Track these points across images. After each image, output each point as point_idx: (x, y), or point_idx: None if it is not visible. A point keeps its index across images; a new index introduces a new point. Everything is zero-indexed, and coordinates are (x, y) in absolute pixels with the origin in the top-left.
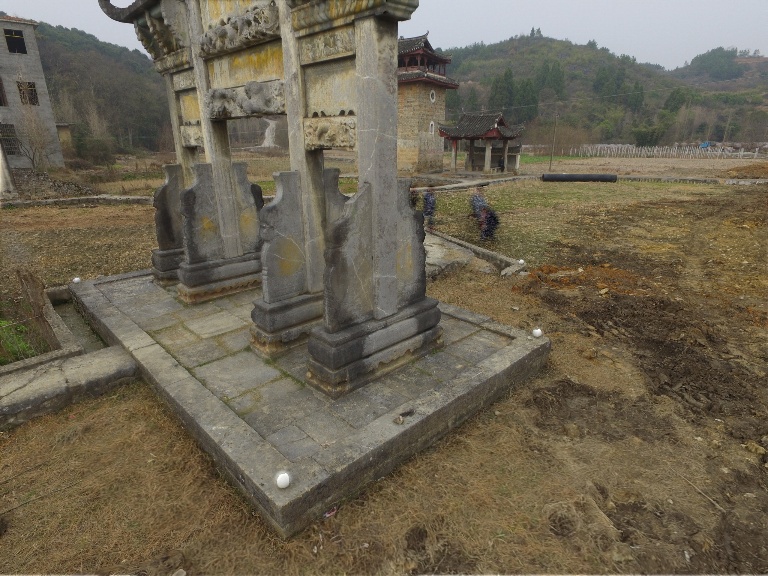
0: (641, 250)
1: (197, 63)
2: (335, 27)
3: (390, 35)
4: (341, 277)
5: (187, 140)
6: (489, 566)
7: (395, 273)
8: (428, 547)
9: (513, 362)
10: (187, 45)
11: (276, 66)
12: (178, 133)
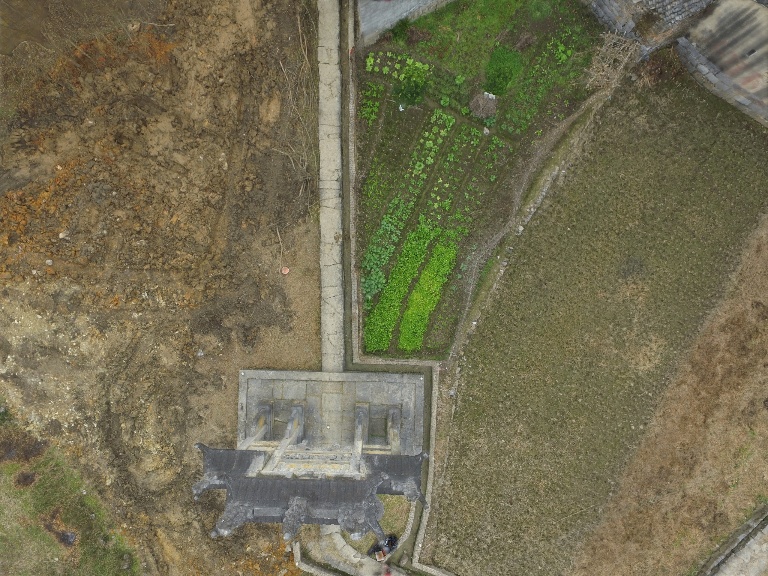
0: None
1: (355, 456)
2: None
3: None
4: None
5: None
6: (213, 391)
7: None
8: (224, 387)
9: None
10: None
11: None
12: None
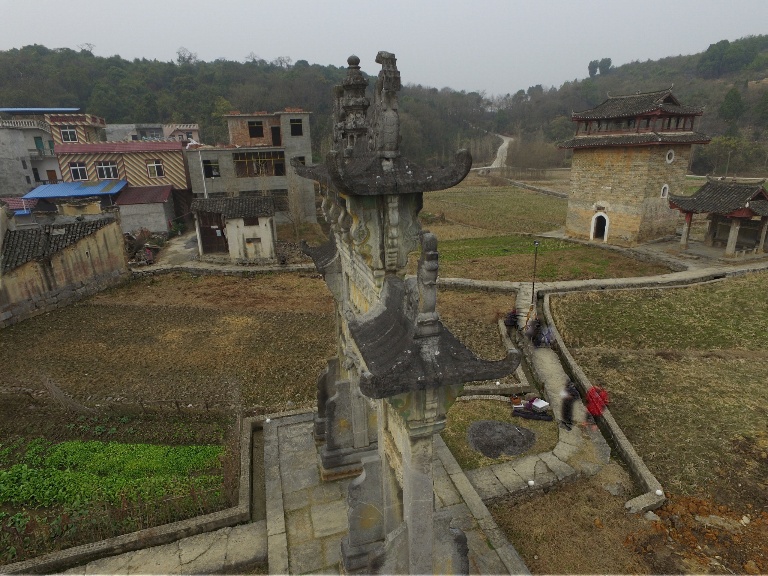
0: None
1: None
2: None
3: (424, 439)
4: None
5: (342, 348)
6: None
7: None
8: None
9: None
10: (341, 300)
11: None
12: (338, 338)
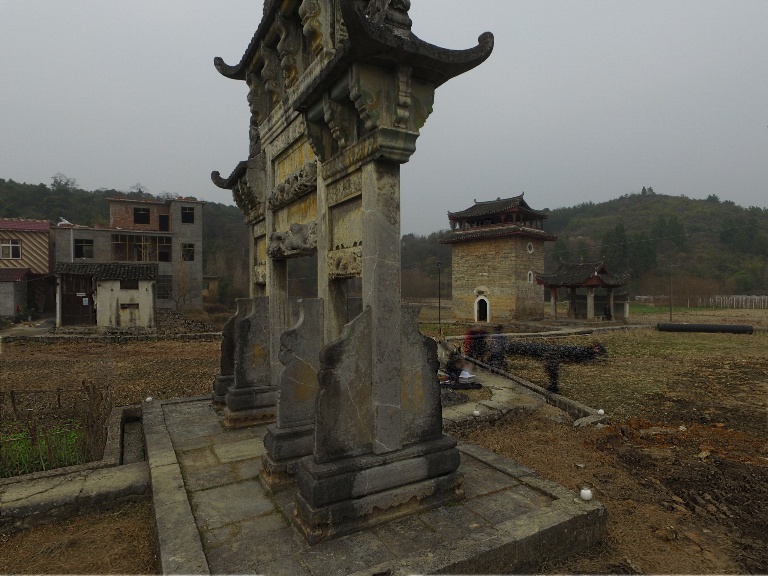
0: None
1: (268, 214)
2: (349, 173)
3: (391, 175)
4: (333, 401)
5: (257, 277)
6: None
7: (398, 403)
8: None
9: (543, 528)
10: (263, 201)
11: (315, 210)
12: (252, 272)
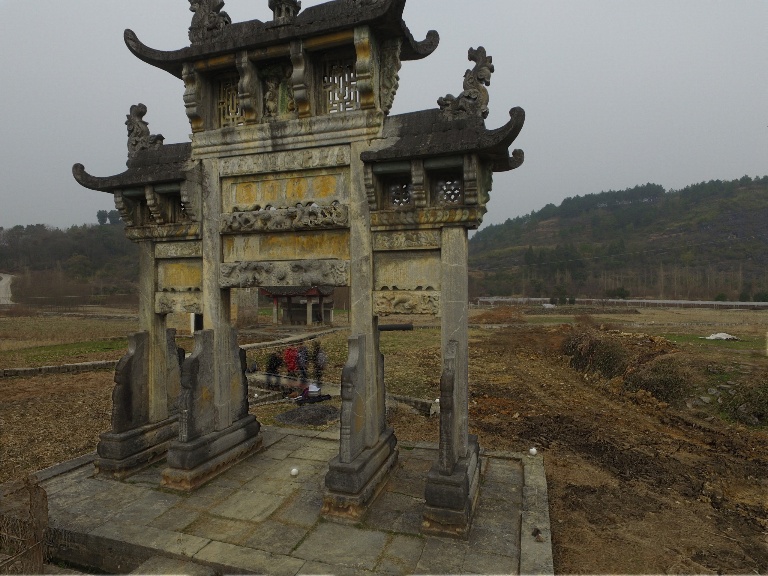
0: (494, 382)
1: (211, 236)
2: (421, 229)
3: None
4: (453, 421)
5: (168, 306)
6: None
7: None
8: None
9: None
10: (199, 220)
11: (334, 248)
12: (151, 299)
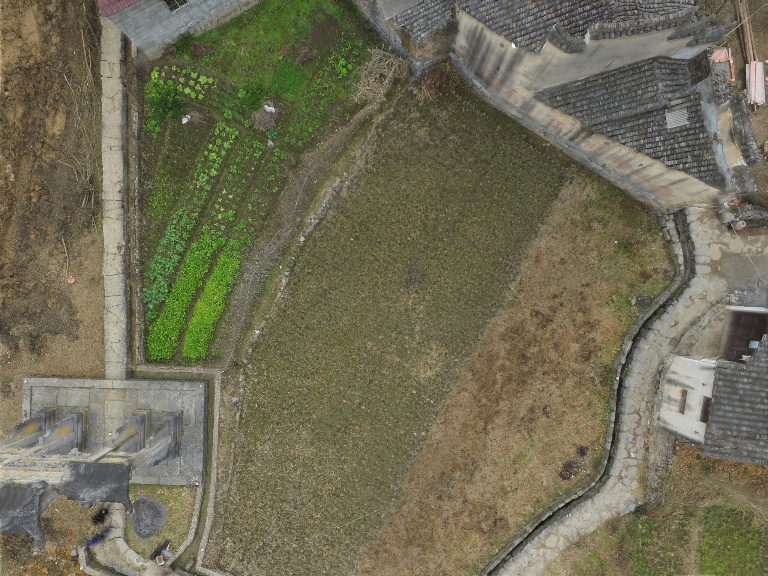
0: None
1: None
2: None
3: None
4: None
5: None
6: (2, 398)
7: None
8: (12, 394)
9: None
10: None
11: None
12: None
